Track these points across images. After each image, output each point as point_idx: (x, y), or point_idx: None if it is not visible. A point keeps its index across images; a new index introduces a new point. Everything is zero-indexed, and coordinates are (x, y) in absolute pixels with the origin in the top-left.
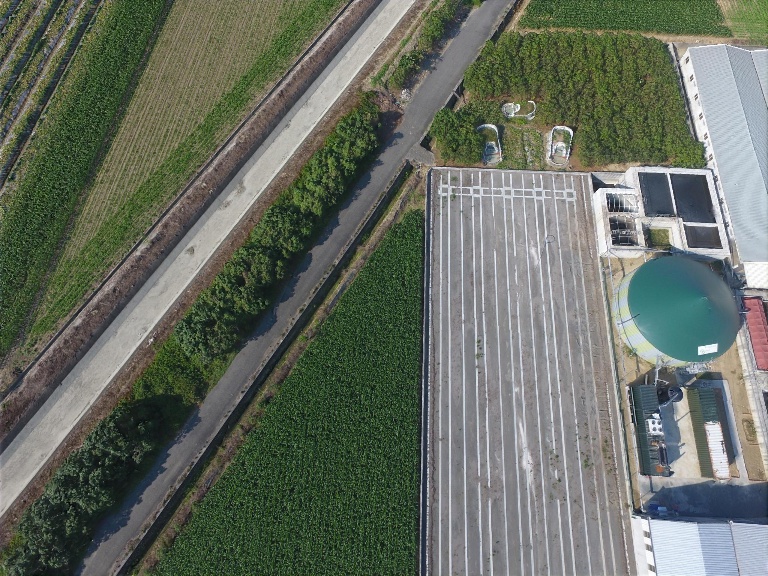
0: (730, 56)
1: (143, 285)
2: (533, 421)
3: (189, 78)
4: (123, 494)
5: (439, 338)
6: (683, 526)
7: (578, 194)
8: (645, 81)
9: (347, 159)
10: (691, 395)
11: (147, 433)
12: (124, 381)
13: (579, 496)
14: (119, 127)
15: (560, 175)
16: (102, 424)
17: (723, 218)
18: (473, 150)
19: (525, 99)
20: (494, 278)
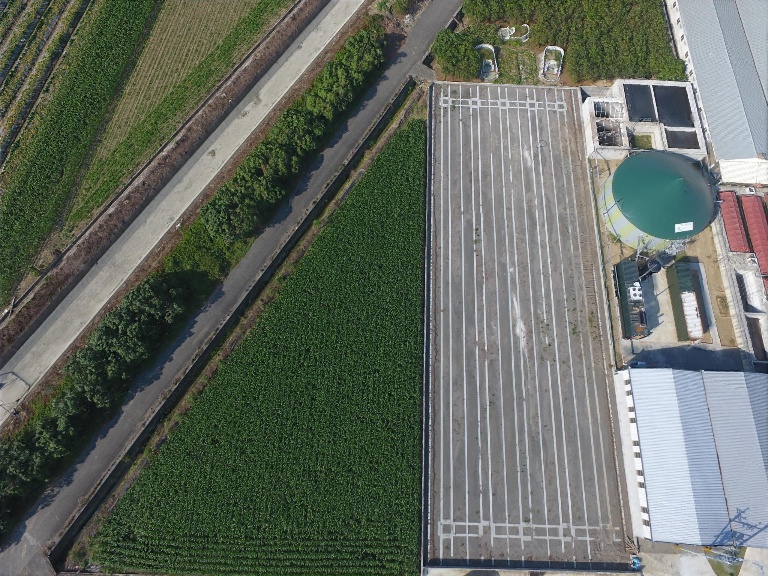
0: None
1: (169, 181)
2: (526, 296)
3: (208, 5)
4: (156, 353)
5: (440, 226)
6: (659, 372)
7: (568, 106)
8: (631, 8)
9: (355, 71)
10: (669, 272)
11: (177, 297)
12: (155, 259)
13: (567, 358)
14: (144, 47)
15: (552, 89)
16: (138, 286)
17: (701, 124)
18: (471, 65)
19: (520, 23)
20: (491, 176)
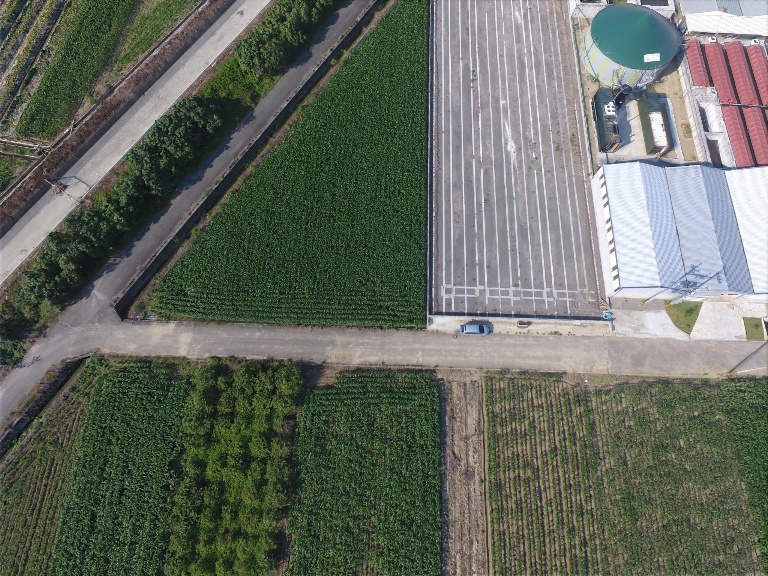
0: None
1: (204, 33)
2: (516, 122)
3: None
4: (198, 161)
5: (442, 69)
6: (628, 165)
7: None
8: None
9: None
10: (640, 101)
11: (217, 112)
12: (195, 88)
13: (551, 168)
14: None
15: None
16: (183, 99)
17: None
18: None
19: None
20: (486, 31)
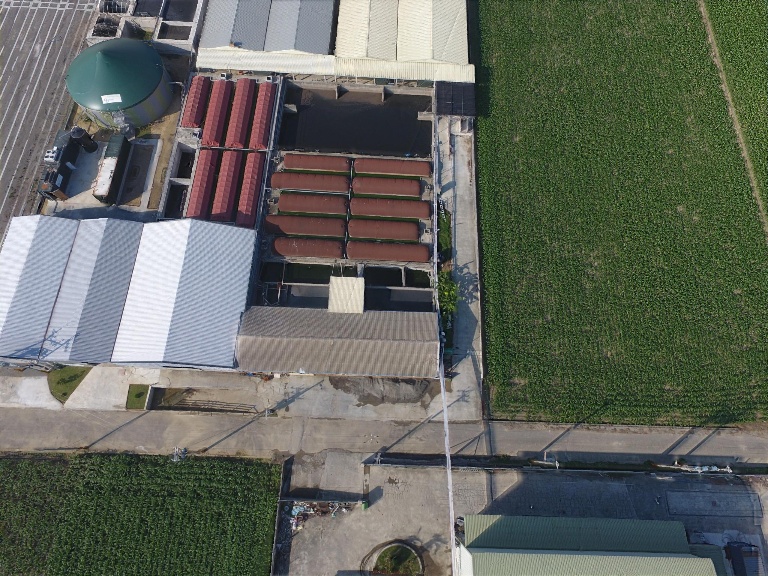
0: None
1: None
2: None
3: None
4: None
5: None
6: (31, 218)
7: None
8: None
9: None
10: None
11: None
12: None
13: None
14: None
15: None
16: None
17: None
18: None
19: None
20: None
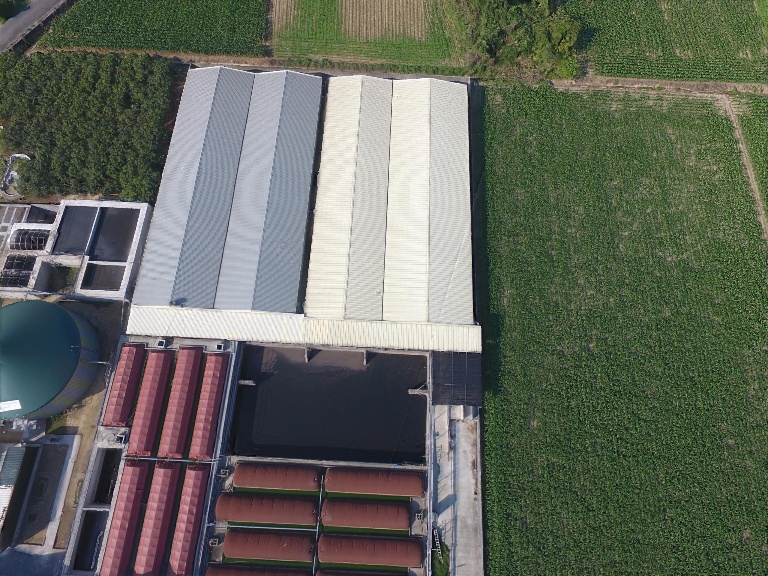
0: (220, 79)
1: None
2: None
3: None
4: None
5: None
6: None
7: None
8: (140, 105)
9: None
10: None
11: None
12: None
13: None
14: None
15: (3, 207)
16: None
17: None
18: None
19: None
20: None
